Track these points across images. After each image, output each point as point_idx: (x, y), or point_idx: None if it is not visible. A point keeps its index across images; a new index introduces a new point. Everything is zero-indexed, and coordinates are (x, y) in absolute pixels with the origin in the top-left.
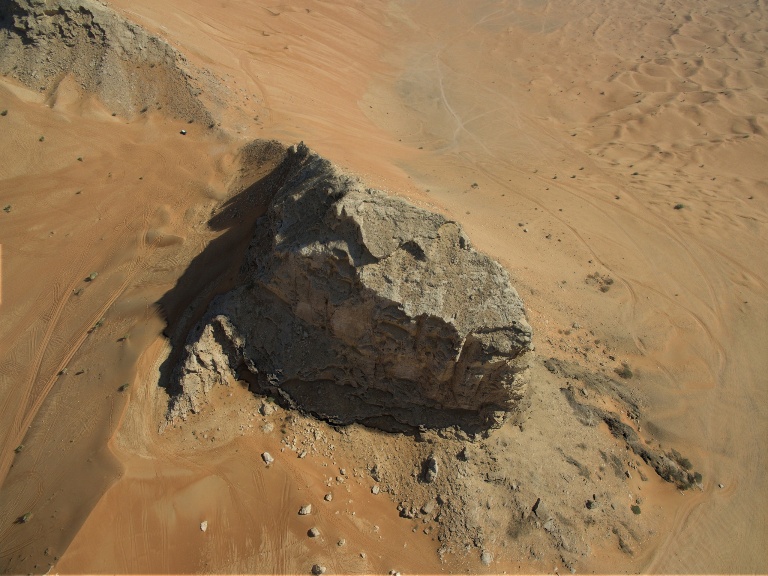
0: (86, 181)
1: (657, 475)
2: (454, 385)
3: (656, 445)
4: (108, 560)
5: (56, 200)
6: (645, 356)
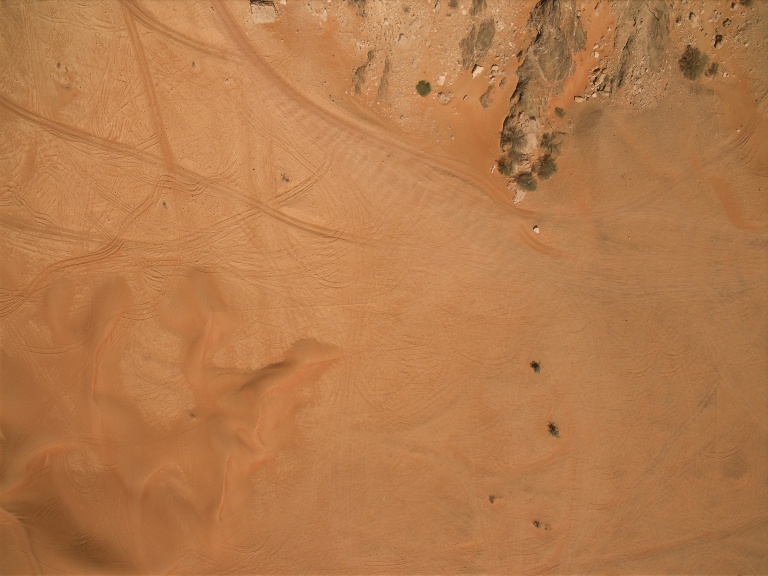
0: None
1: (502, 122)
2: None
3: (561, 127)
4: None
5: None
6: (756, 106)
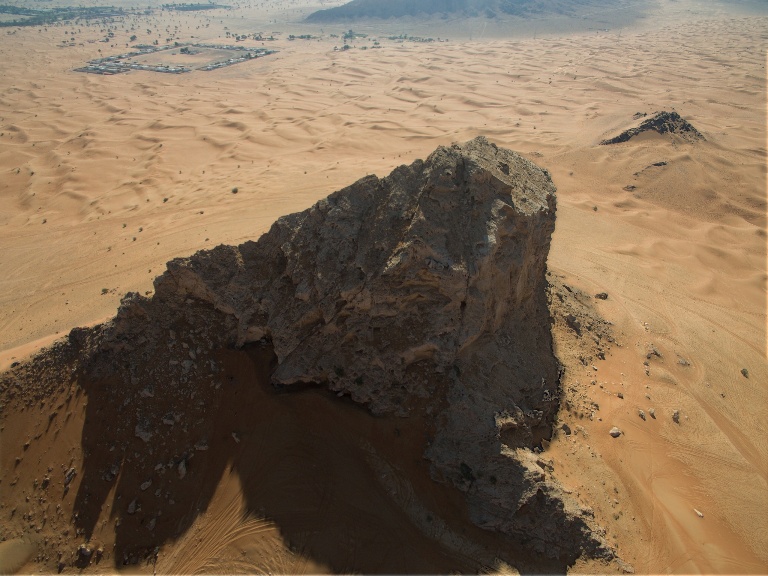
0: None
1: None
2: (545, 253)
3: None
4: None
5: None
6: None
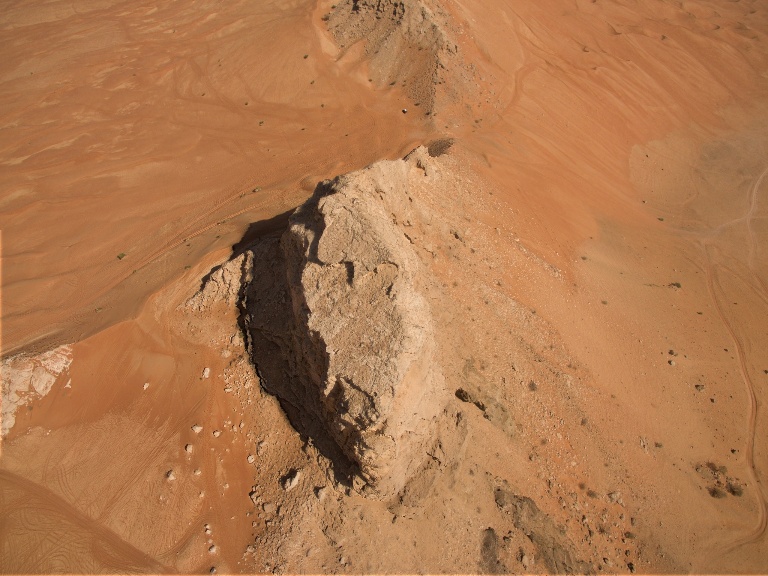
0: (314, 123)
1: None
2: None
3: None
4: (96, 363)
5: (288, 129)
6: None
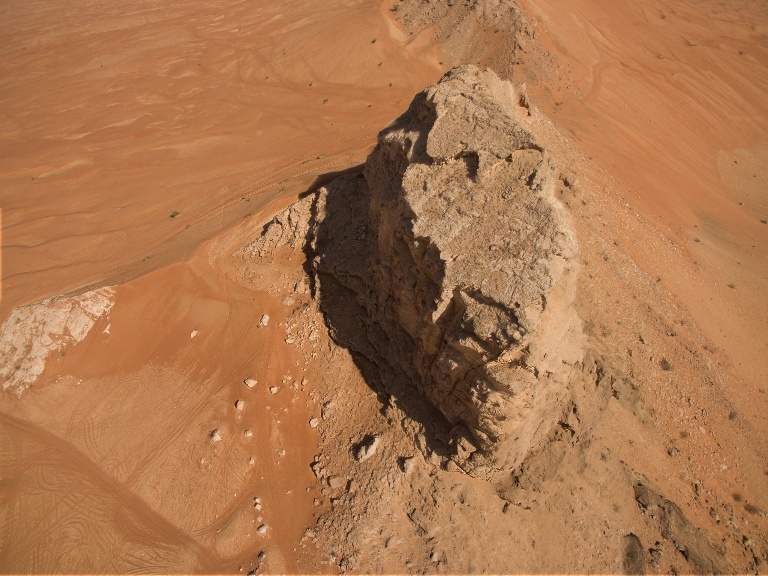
0: (381, 100)
1: None
2: (433, 363)
3: None
4: (140, 307)
5: (354, 106)
6: None
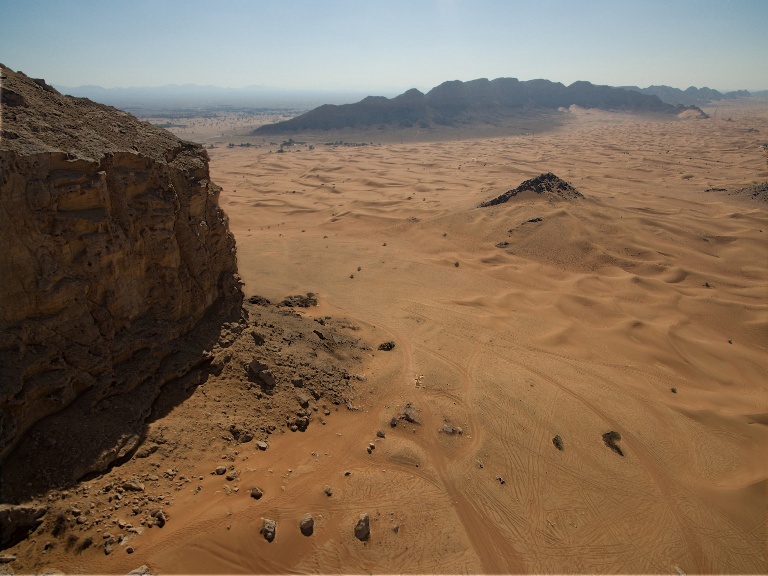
0: None
1: (303, 308)
2: (191, 261)
3: None
4: None
5: None
6: None
